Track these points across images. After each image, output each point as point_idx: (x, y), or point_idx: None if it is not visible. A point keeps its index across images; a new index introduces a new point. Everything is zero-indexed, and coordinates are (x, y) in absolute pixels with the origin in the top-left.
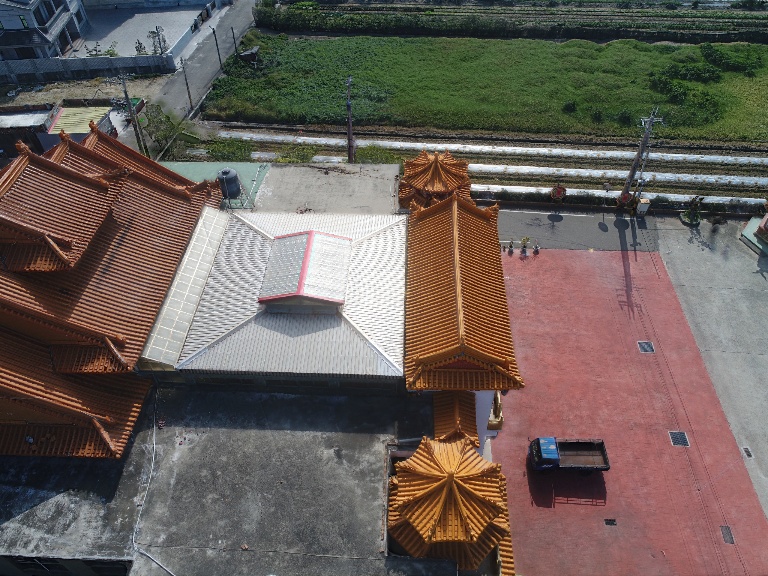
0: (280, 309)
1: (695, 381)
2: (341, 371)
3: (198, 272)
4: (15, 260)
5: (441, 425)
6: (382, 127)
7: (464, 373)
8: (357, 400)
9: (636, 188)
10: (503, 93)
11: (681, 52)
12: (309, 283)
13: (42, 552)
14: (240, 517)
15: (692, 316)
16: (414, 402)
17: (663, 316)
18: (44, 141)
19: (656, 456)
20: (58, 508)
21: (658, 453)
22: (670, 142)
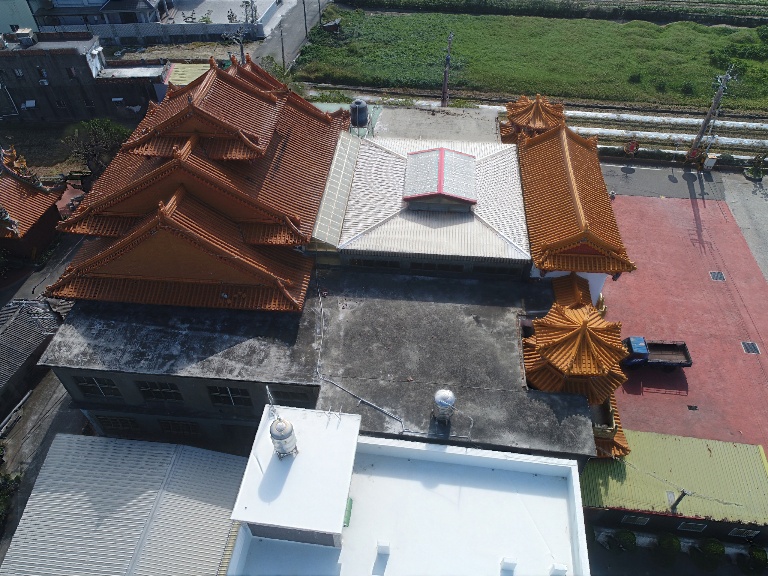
0: (420, 207)
1: (763, 304)
2: (478, 254)
3: (343, 180)
4: (214, 150)
5: (563, 301)
6: (460, 91)
7: (584, 258)
8: (487, 283)
9: (704, 145)
10: (572, 65)
11: (739, 34)
12: (446, 185)
13: (245, 377)
14: (402, 360)
15: (758, 253)
16: (536, 286)
17: (732, 252)
18: (159, 91)
19: (731, 360)
20: (251, 348)
21: (732, 358)
22: (731, 111)
